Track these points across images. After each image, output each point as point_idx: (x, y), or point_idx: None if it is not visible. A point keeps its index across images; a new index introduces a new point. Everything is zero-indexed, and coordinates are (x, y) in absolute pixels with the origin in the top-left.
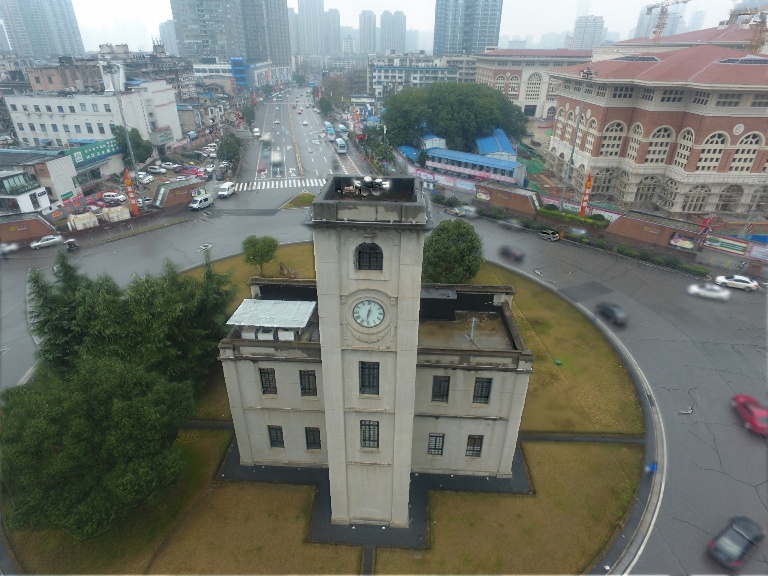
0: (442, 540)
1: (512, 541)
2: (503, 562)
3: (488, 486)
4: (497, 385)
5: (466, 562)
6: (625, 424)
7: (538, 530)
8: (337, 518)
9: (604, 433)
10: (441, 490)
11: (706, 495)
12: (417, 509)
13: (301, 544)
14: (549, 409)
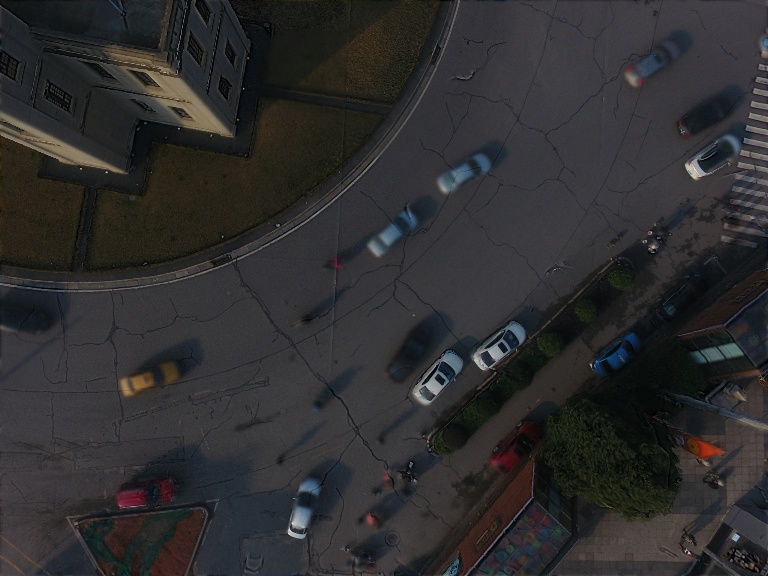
0: (153, 189)
1: (209, 197)
2: (196, 213)
3: (210, 143)
4: (155, 78)
5: (167, 209)
6: (381, 88)
7: (235, 191)
8: (63, 161)
9: (351, 97)
10: (164, 143)
11: (406, 175)
12: (139, 158)
13: (36, 178)
14: (308, 58)
